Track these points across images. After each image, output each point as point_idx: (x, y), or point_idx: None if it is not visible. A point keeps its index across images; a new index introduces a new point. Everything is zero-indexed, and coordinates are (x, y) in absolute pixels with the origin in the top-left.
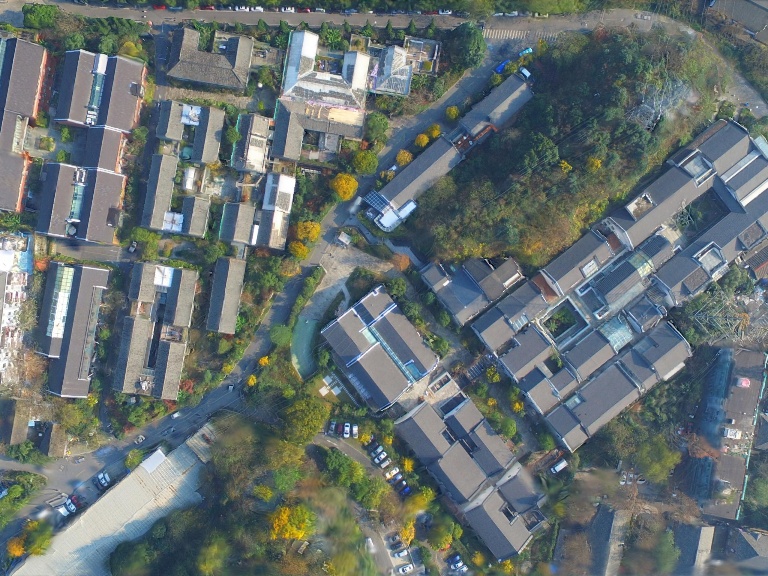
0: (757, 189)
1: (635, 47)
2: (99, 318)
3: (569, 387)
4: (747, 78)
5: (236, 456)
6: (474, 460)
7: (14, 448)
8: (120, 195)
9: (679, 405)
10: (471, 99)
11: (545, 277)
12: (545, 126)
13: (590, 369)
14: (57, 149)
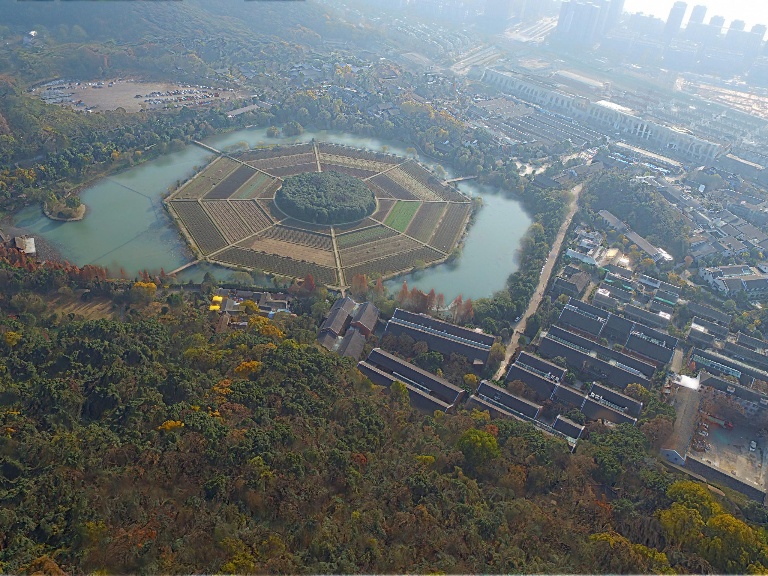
0: (658, 183)
1: None
2: None
3: None
4: None
5: None
6: None
7: None
8: None
9: None
10: None
11: None
12: None
13: None
14: None
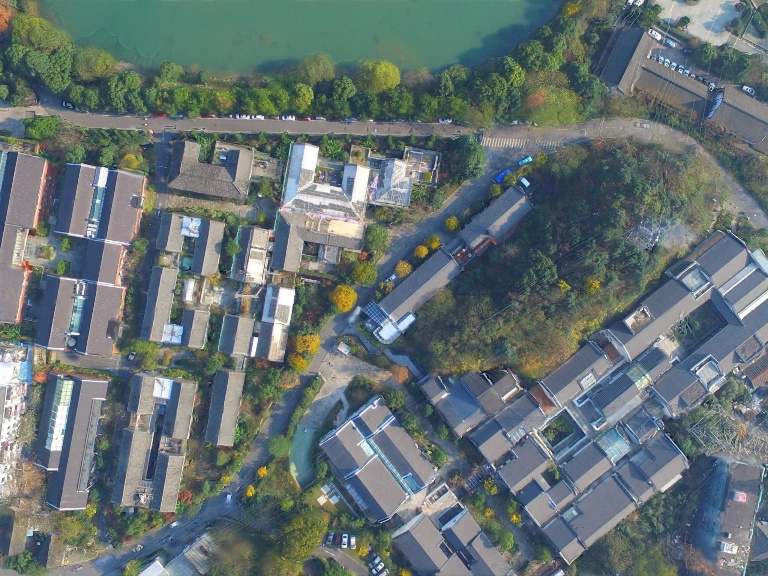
0: (755, 302)
1: (634, 164)
2: (98, 430)
3: (566, 500)
4: (745, 187)
5: (234, 573)
6: (471, 572)
7: (12, 559)
8: (120, 307)
9: (676, 515)
10: (470, 210)
11: (543, 388)
12: (544, 243)
13: (587, 481)
14: (57, 258)
